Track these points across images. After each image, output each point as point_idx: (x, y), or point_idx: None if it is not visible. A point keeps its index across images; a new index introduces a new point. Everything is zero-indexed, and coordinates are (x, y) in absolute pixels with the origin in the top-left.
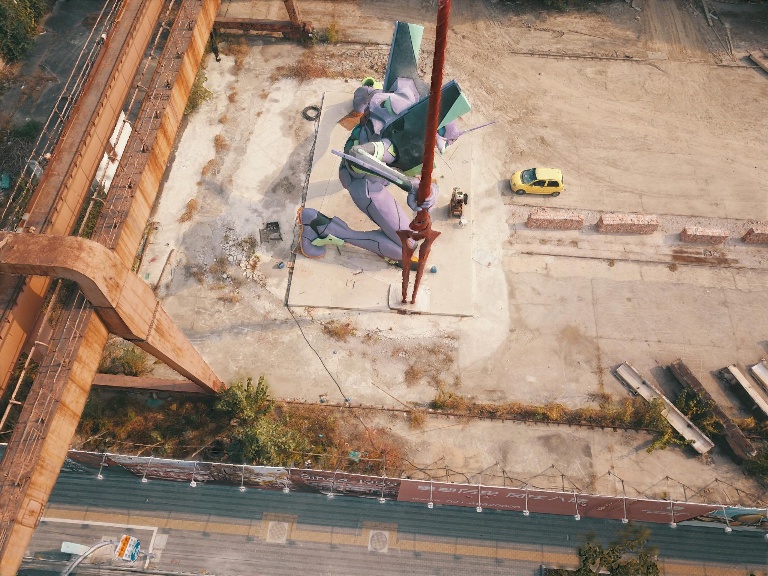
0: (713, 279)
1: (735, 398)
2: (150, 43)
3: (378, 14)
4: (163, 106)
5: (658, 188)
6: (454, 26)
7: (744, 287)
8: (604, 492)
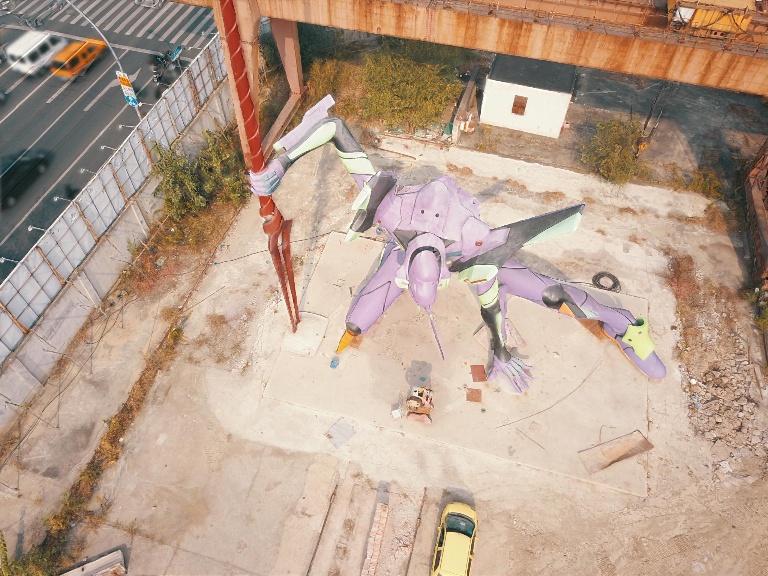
0: None
1: None
2: (712, 149)
3: None
4: None
5: None
6: None
7: None
8: (3, 474)
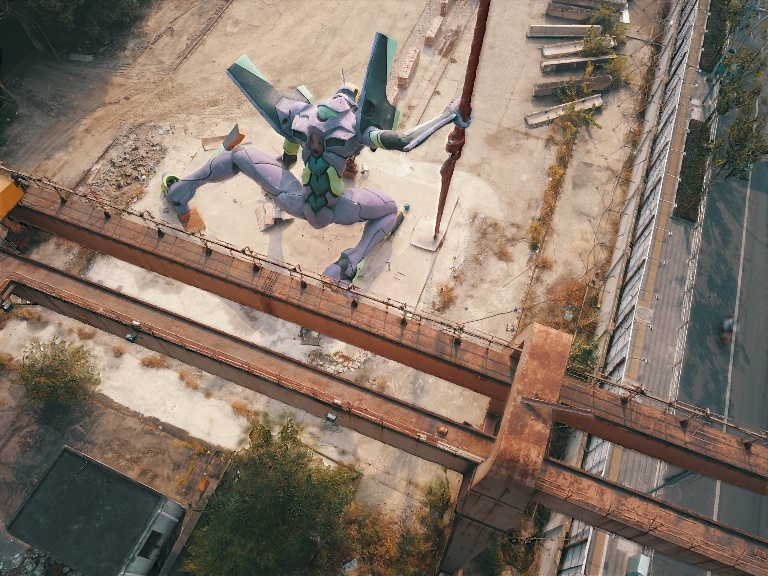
0: None
1: (564, 73)
2: None
3: (39, 158)
4: None
5: None
6: (105, 101)
7: None
8: (619, 167)
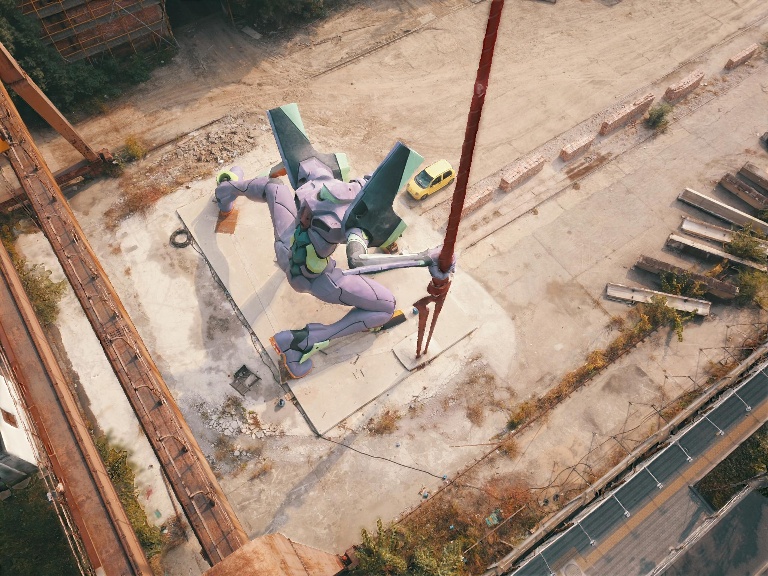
0: (607, 178)
1: (690, 258)
2: None
3: (161, 105)
4: (134, 341)
5: (516, 129)
6: (242, 79)
7: (630, 170)
8: (675, 394)
